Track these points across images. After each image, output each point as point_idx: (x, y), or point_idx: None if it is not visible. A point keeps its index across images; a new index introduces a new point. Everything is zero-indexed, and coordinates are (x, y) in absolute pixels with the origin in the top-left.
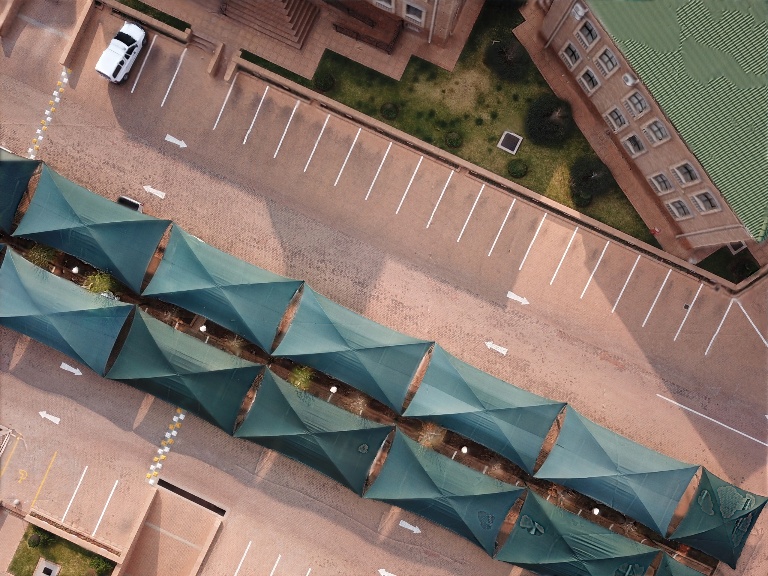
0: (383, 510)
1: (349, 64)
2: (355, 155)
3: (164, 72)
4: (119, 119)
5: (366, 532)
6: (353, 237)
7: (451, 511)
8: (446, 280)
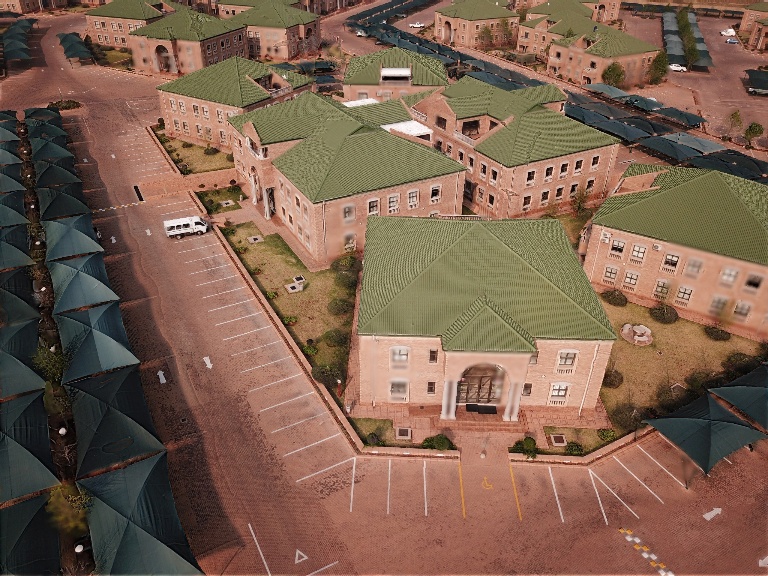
0: None
1: None
2: None
3: None
4: None
5: None
6: None
7: None
8: None
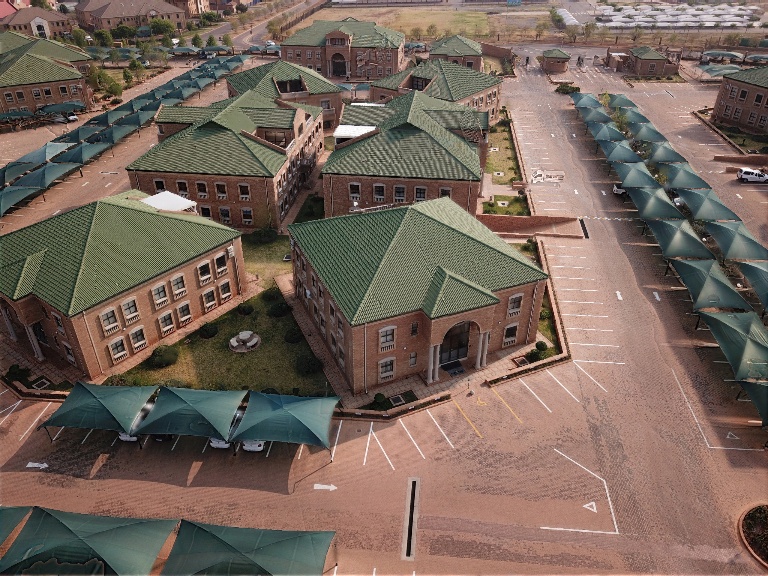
0: (654, 285)
1: None
2: None
3: None
4: (725, 184)
5: (634, 282)
6: None
7: (703, 279)
8: None
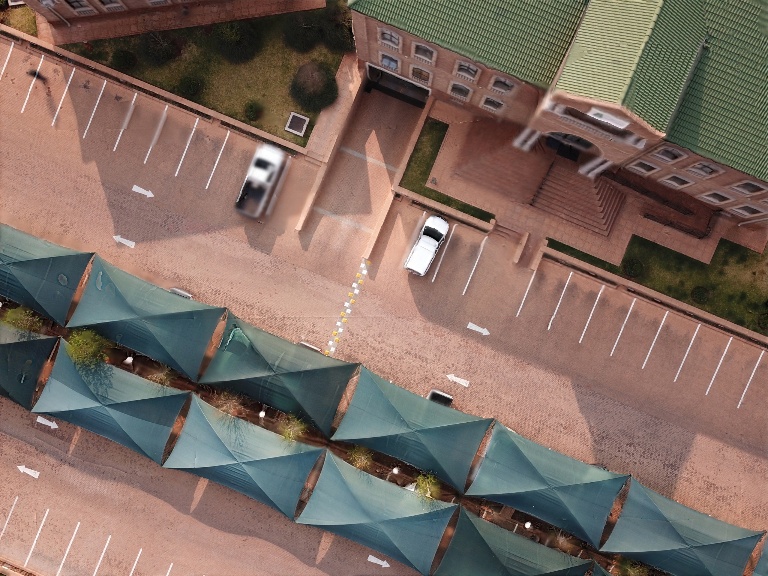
0: None
1: (657, 249)
2: (662, 338)
3: (465, 261)
4: (420, 309)
5: None
6: (662, 419)
7: None
8: (758, 459)
